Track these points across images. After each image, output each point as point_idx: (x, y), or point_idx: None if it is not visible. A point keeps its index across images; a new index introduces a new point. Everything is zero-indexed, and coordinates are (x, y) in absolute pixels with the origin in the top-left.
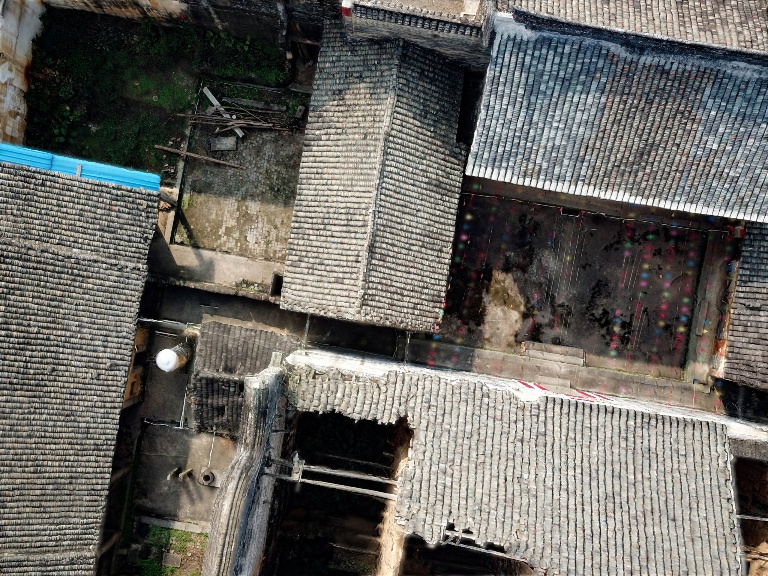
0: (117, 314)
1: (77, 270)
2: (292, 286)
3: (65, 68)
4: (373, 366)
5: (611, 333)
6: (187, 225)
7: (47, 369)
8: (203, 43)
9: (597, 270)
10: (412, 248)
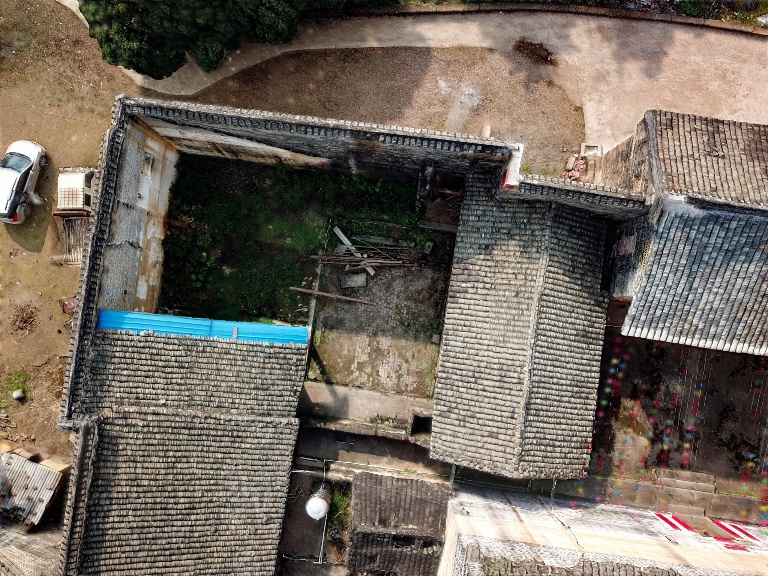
0: (272, 469)
1: (236, 431)
2: (442, 437)
3: (201, 215)
4: (532, 522)
5: (740, 458)
6: (319, 361)
7: (210, 530)
8: (334, 185)
9: (724, 396)
10: (562, 400)
